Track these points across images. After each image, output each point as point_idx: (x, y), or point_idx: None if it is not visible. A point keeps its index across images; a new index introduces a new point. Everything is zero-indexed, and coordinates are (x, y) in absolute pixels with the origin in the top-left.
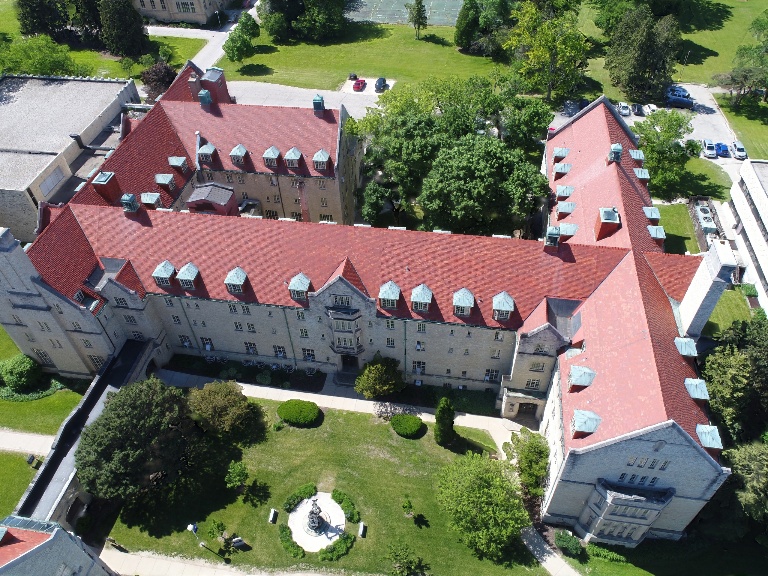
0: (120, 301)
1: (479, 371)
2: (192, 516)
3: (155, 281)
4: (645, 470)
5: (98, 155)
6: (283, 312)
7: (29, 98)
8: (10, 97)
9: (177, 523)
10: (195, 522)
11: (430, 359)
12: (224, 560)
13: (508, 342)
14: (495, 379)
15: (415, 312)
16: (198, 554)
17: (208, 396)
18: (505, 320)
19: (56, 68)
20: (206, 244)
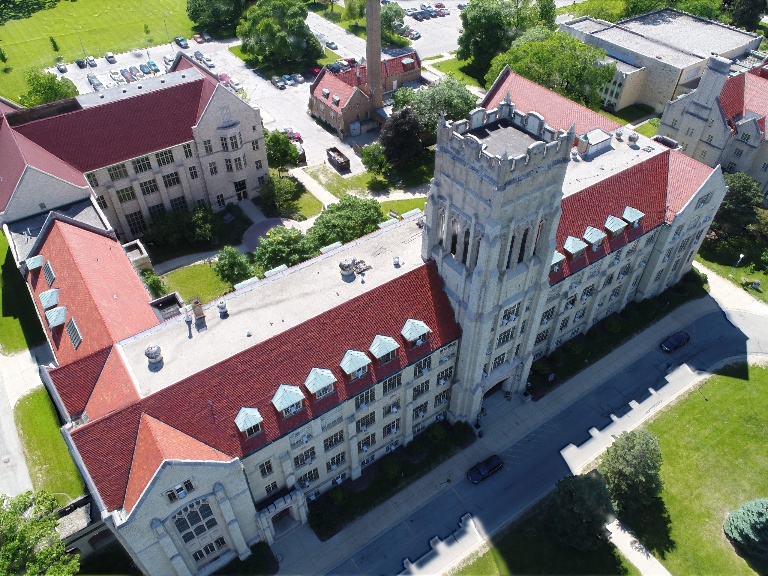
0: (745, 137)
1: None
2: (729, 262)
3: None
4: None
5: None
6: None
7: (683, 25)
8: (669, 21)
9: (718, 260)
10: (730, 265)
11: None
12: (743, 288)
13: None
14: None
15: None
16: (728, 278)
17: (767, 213)
18: None
19: (705, 14)
20: None
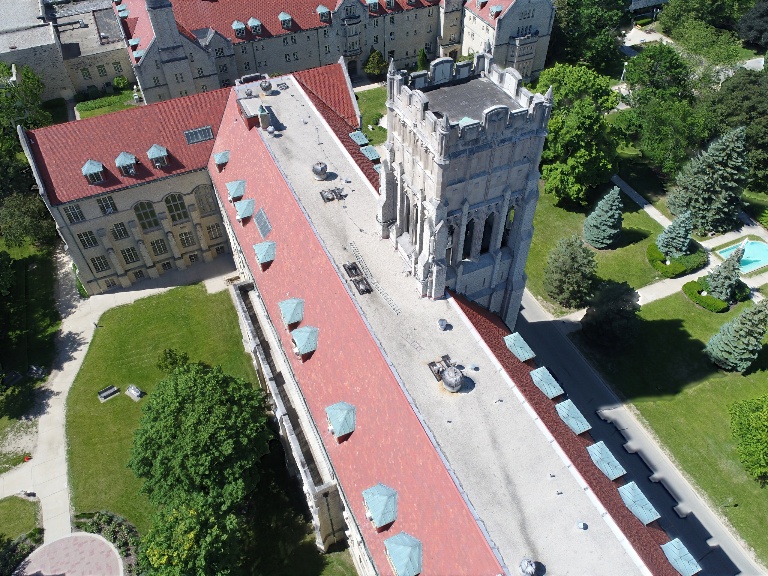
0: (219, 52)
1: (422, 47)
2: None
3: (235, 34)
4: (526, 20)
5: (65, 30)
6: (317, 33)
7: None
8: None
9: None
10: None
11: (397, 46)
12: None
13: (435, 16)
14: (430, 51)
15: (388, 9)
16: None
17: None
18: (432, 0)
19: None
20: (257, 3)
